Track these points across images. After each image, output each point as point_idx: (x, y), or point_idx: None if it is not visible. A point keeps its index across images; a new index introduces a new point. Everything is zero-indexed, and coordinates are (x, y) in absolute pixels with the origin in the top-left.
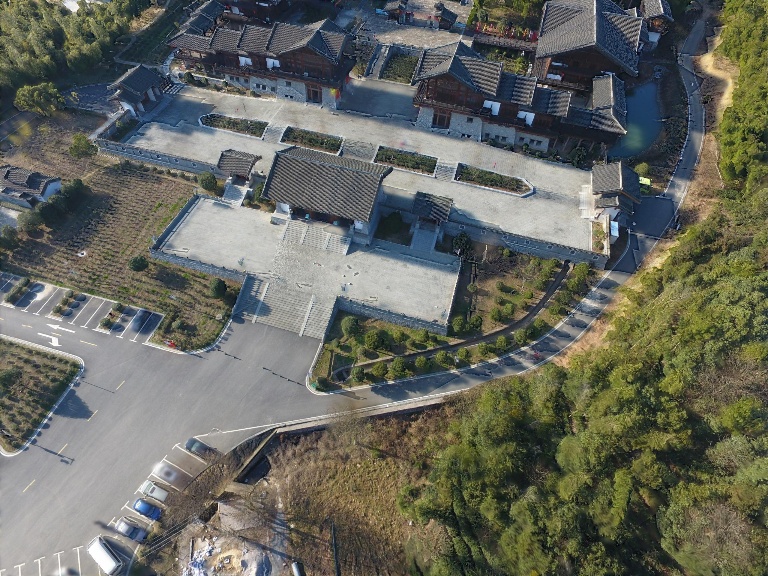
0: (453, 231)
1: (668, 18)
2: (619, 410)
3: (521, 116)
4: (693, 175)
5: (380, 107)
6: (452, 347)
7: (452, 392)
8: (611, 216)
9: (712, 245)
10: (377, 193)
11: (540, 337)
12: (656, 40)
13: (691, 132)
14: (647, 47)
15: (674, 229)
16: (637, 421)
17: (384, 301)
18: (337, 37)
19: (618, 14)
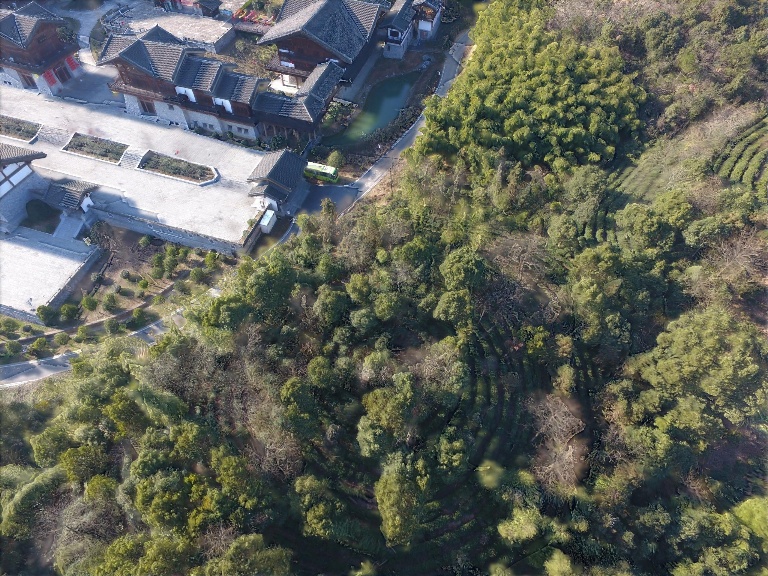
0: (106, 219)
1: (431, 6)
2: (79, 400)
3: (219, 103)
4: (395, 164)
5: (102, 94)
6: (50, 337)
7: (18, 383)
8: (272, 205)
9: (317, 233)
10: None
11: (143, 327)
12: (430, 29)
13: (419, 121)
14: (424, 36)
15: None
16: (80, 412)
17: None
18: (30, 21)
19: (356, 1)
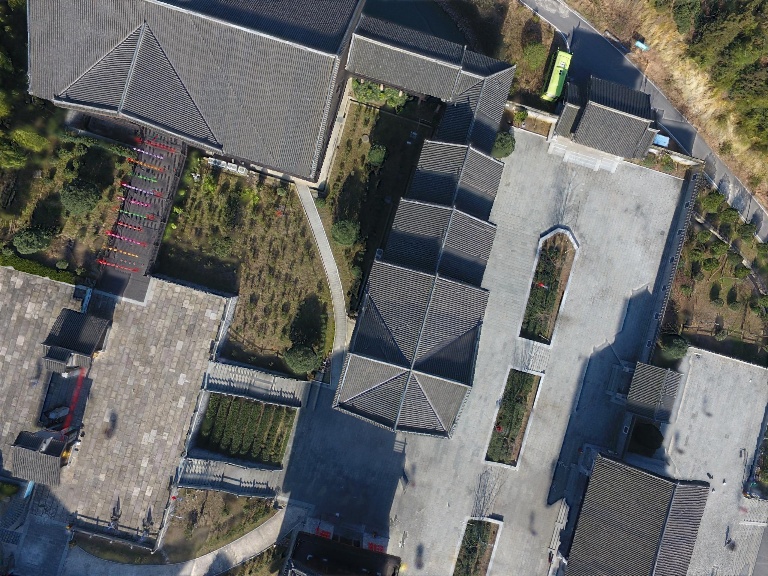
0: None
1: None
2: None
3: None
4: None
5: (377, 463)
6: None
7: None
8: None
9: None
10: (689, 483)
11: None
12: None
13: None
14: None
15: (631, 49)
16: None
17: (745, 441)
18: None
19: None
